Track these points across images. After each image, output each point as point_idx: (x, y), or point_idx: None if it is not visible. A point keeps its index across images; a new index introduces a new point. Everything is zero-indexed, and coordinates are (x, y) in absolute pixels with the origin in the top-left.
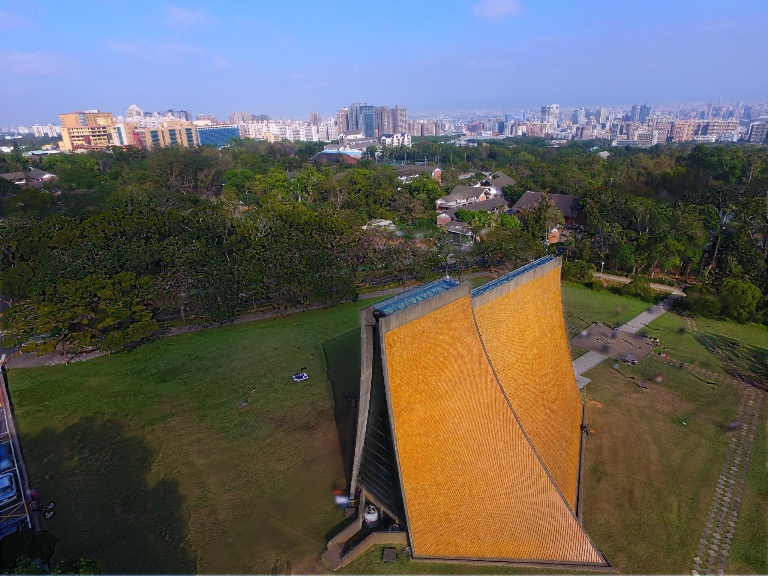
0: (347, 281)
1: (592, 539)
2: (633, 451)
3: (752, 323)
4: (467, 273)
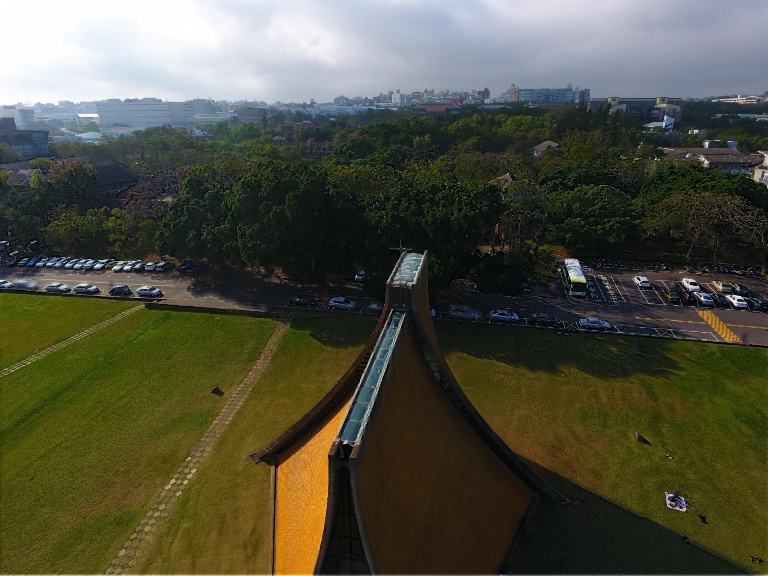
0: None
1: (263, 468)
2: None
3: None
4: None
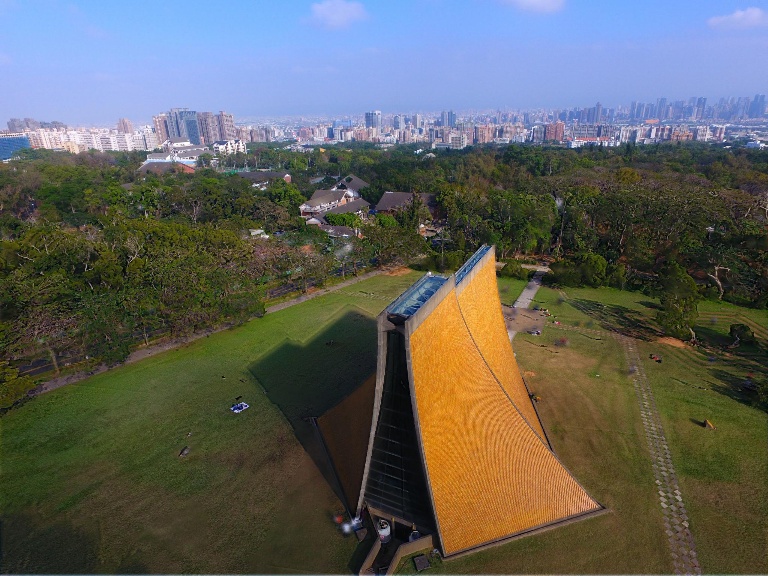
0: (255, 296)
1: None
2: (575, 407)
3: (602, 287)
4: (361, 274)
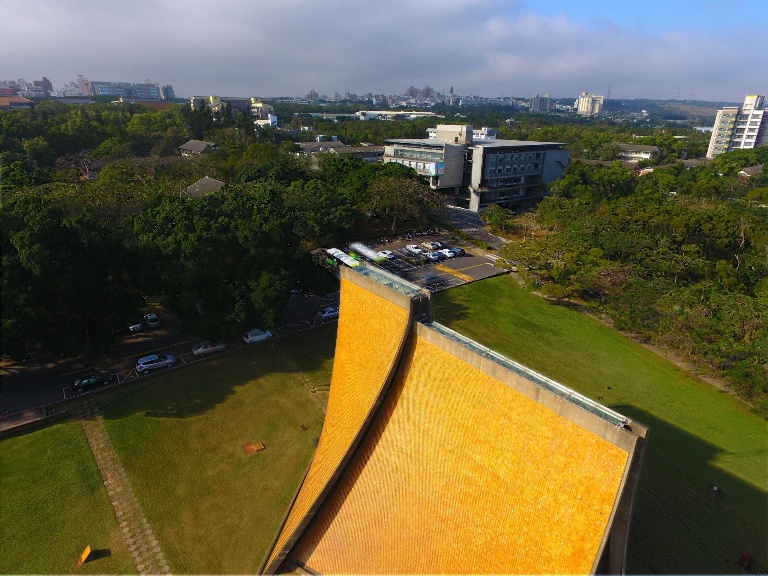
0: None
1: None
2: None
3: None
4: None
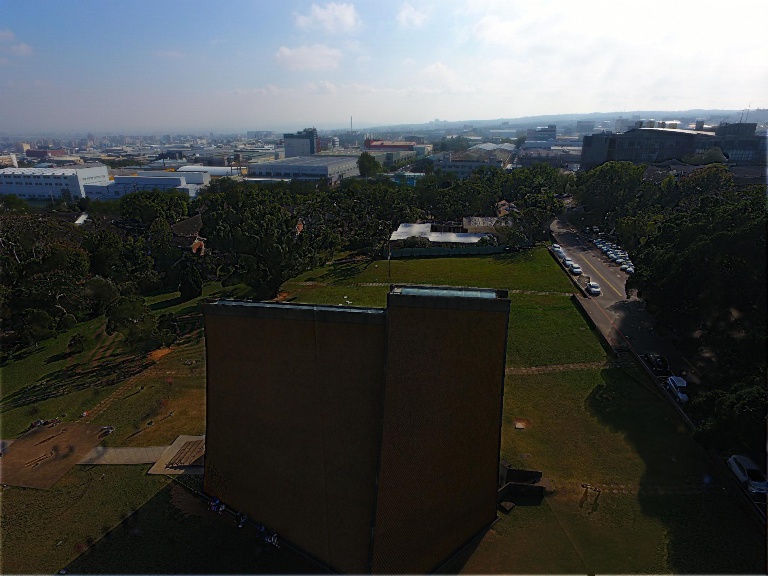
0: None
1: None
2: None
3: None
4: None
